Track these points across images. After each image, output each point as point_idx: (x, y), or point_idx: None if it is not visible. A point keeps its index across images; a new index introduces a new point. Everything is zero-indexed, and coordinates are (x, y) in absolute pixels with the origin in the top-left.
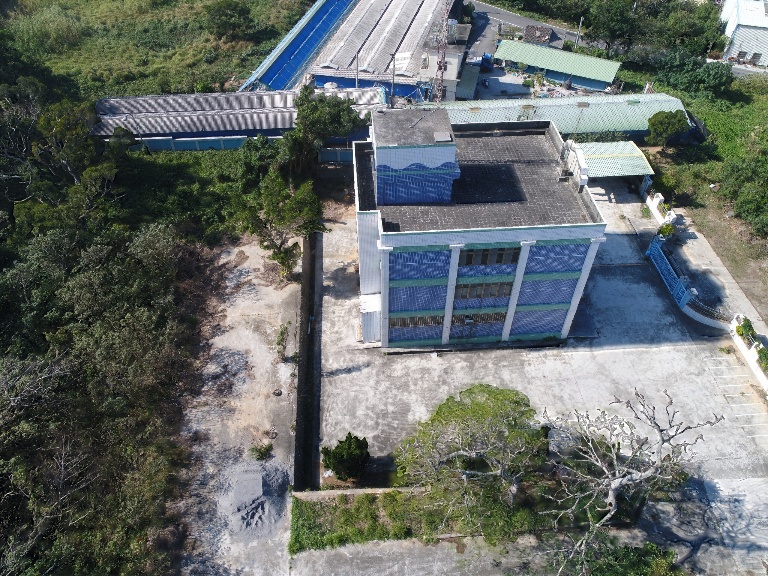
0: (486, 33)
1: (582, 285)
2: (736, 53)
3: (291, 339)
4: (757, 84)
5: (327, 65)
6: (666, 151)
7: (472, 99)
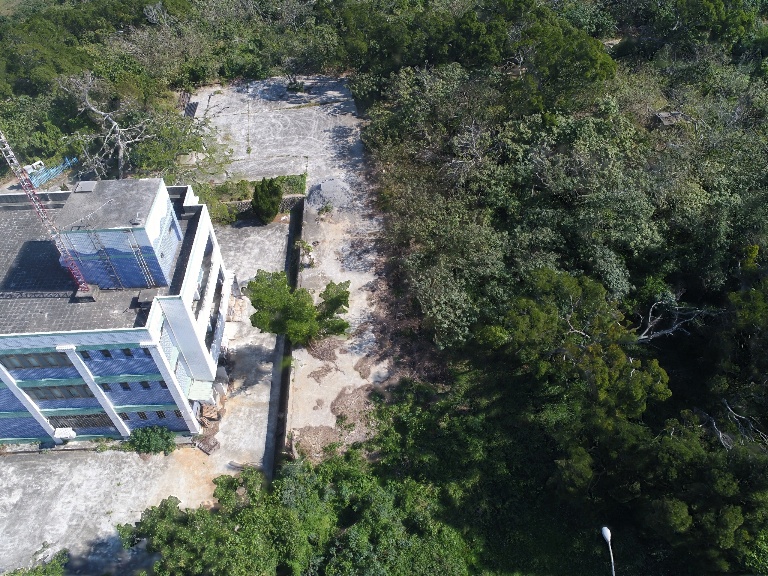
0: None
1: None
2: None
3: (305, 281)
4: None
5: None
6: None
7: None
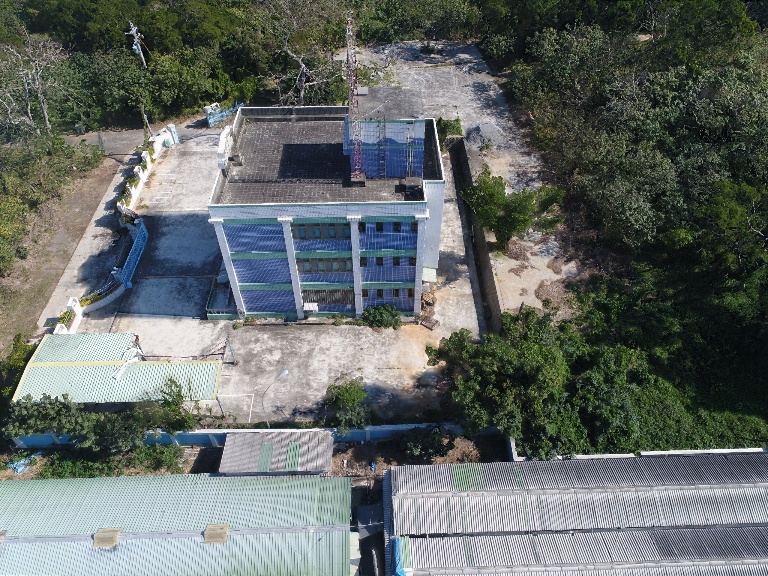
0: None
1: None
2: None
3: None
4: None
5: None
6: None
7: None
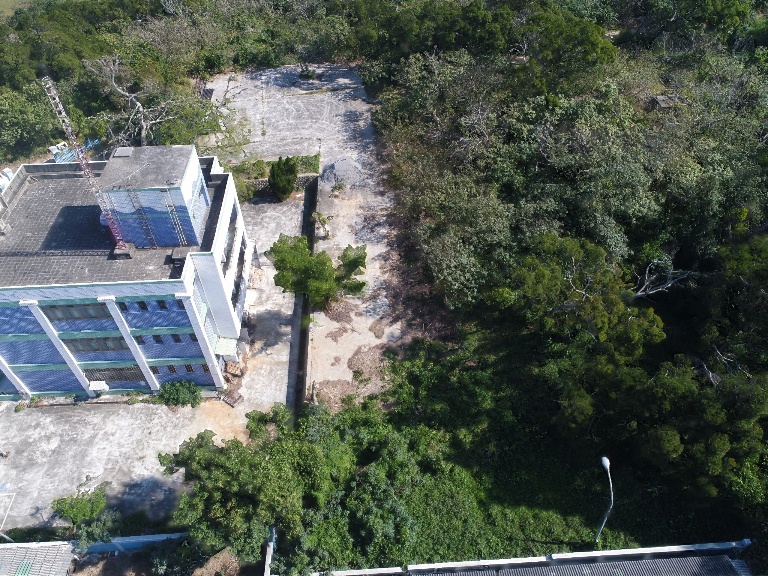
0: None
1: None
2: None
3: None
4: None
5: None
6: None
7: None
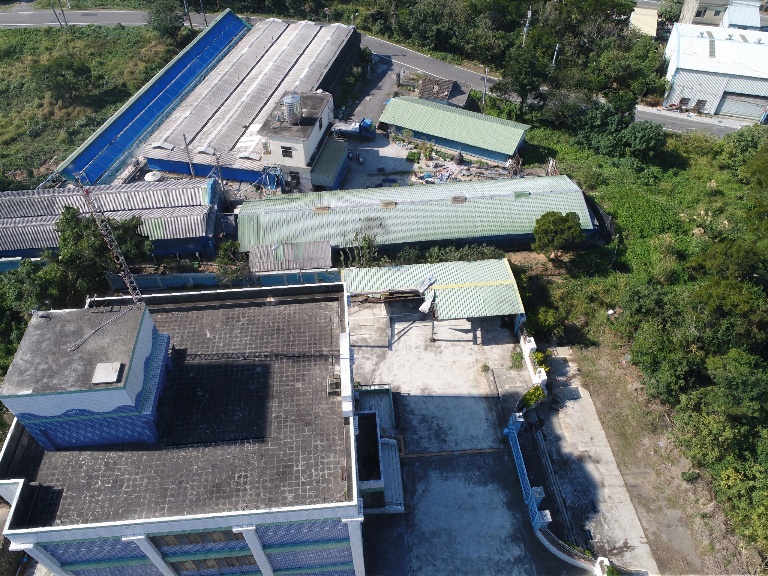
0: (383, 83)
1: (358, 552)
2: (677, 99)
3: None
4: (695, 144)
5: (159, 145)
6: (561, 258)
7: (332, 187)
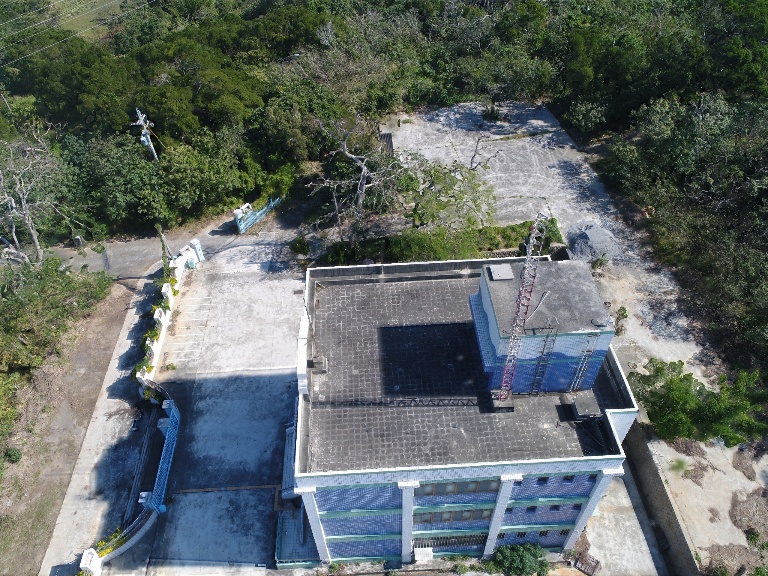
0: None
1: None
2: None
3: (618, 353)
4: None
5: None
6: None
7: None
